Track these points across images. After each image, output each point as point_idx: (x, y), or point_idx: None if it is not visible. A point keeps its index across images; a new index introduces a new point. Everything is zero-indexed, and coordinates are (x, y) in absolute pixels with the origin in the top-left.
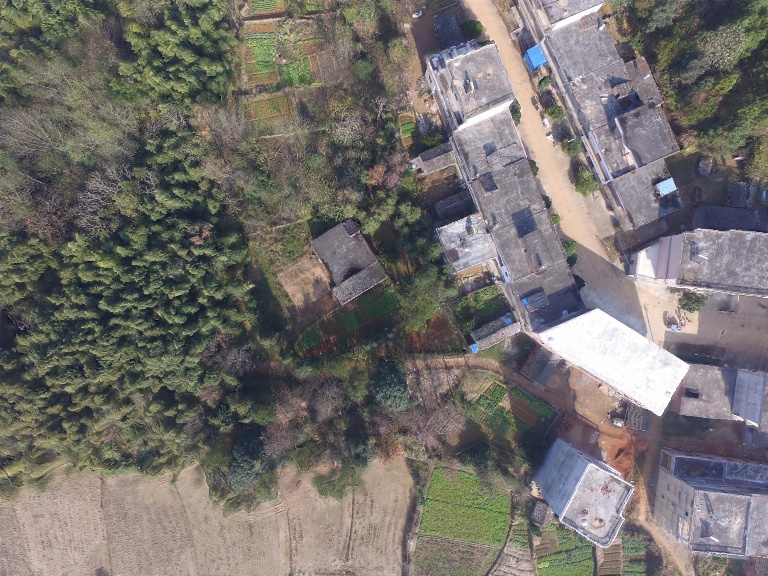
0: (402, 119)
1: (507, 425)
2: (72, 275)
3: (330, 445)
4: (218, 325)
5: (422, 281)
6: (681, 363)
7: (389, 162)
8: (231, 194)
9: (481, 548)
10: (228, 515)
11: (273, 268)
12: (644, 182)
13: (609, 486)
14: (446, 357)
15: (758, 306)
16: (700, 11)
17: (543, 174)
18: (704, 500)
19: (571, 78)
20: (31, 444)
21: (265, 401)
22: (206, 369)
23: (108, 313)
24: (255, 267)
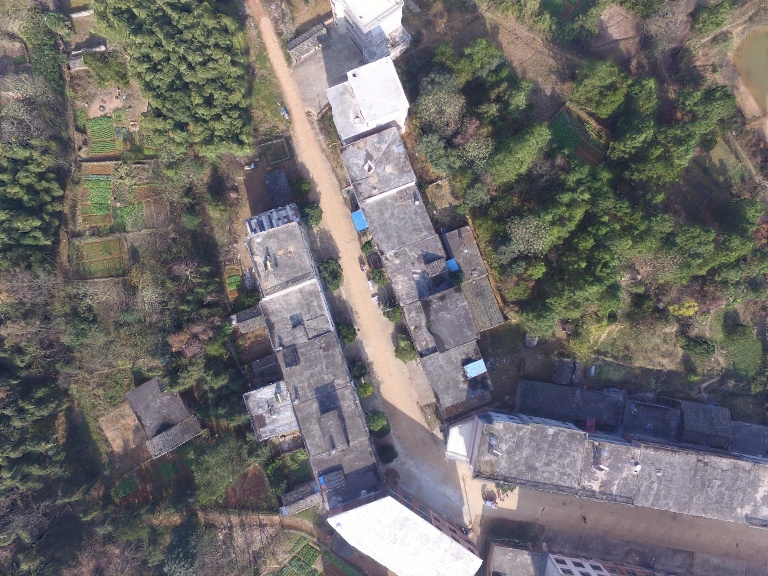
0: (229, 271)
1: None
2: None
3: None
4: (15, 482)
5: (210, 459)
6: (474, 558)
7: (191, 330)
8: (41, 347)
9: None
10: None
11: (94, 412)
12: (453, 362)
13: None
14: (261, 514)
15: None
16: (520, 189)
17: (366, 336)
18: None
19: (383, 252)
20: None
21: (64, 557)
22: None
23: None
24: (77, 410)
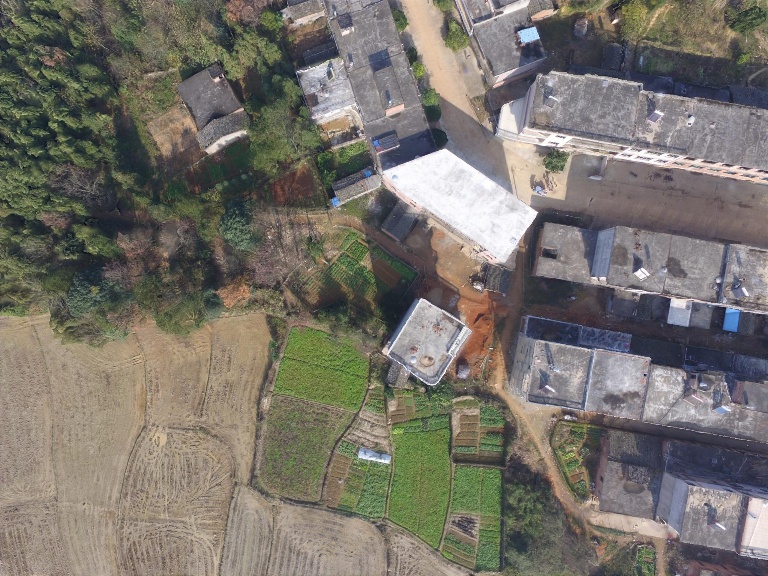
0: None
1: (368, 285)
2: None
3: (189, 296)
4: (69, 153)
5: (267, 111)
6: (529, 209)
7: None
8: (94, 28)
9: (336, 410)
10: (66, 342)
11: (143, 116)
12: (506, 30)
13: (441, 324)
14: (310, 213)
15: (629, 174)
16: None
17: (415, 30)
18: (545, 351)
19: None
20: None
21: (116, 237)
22: (51, 192)
23: None
24: (125, 114)
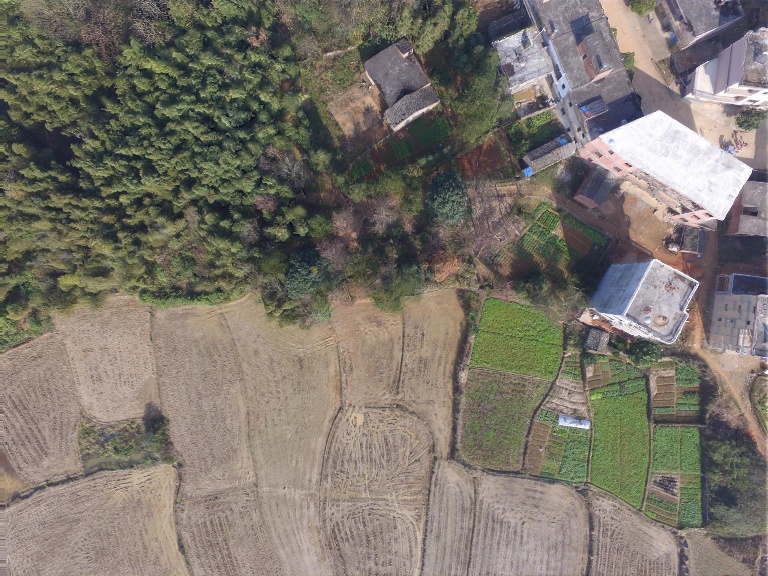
0: None
1: (560, 254)
2: (127, 85)
3: (381, 275)
4: (273, 136)
5: (482, 81)
6: (744, 166)
7: None
8: (285, 8)
9: (533, 380)
10: (284, 325)
11: (323, 97)
12: None
13: (673, 283)
14: (498, 185)
15: None
16: None
17: None
18: (767, 305)
19: None
20: (86, 255)
21: None
22: (263, 175)
23: (164, 118)
24: None
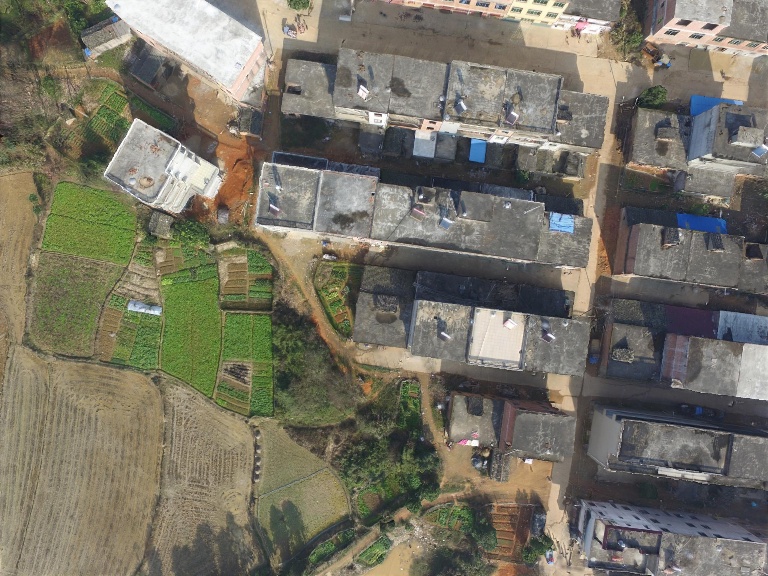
0: None
1: None
2: None
3: None
4: None
5: None
6: (252, 35)
7: None
8: None
9: (105, 265)
10: None
11: None
12: None
13: (159, 145)
14: (68, 67)
15: (380, 15)
16: None
17: None
18: (272, 173)
19: None
20: None
21: None
22: None
23: None
24: None
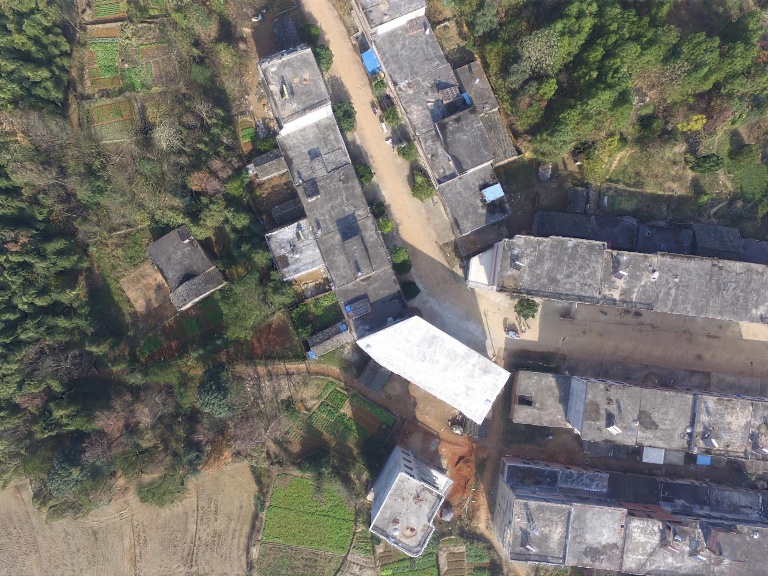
0: (242, 124)
1: (349, 432)
2: None
3: (172, 451)
4: (42, 332)
5: (237, 288)
6: (501, 371)
7: (210, 168)
8: (59, 200)
9: (324, 555)
10: (50, 522)
11: (115, 274)
12: (471, 188)
13: (421, 495)
14: (287, 363)
15: (600, 313)
16: (528, 15)
17: (382, 179)
18: (524, 509)
19: (397, 83)
20: None
21: (94, 408)
22: (25, 376)
23: None
24: (97, 273)
